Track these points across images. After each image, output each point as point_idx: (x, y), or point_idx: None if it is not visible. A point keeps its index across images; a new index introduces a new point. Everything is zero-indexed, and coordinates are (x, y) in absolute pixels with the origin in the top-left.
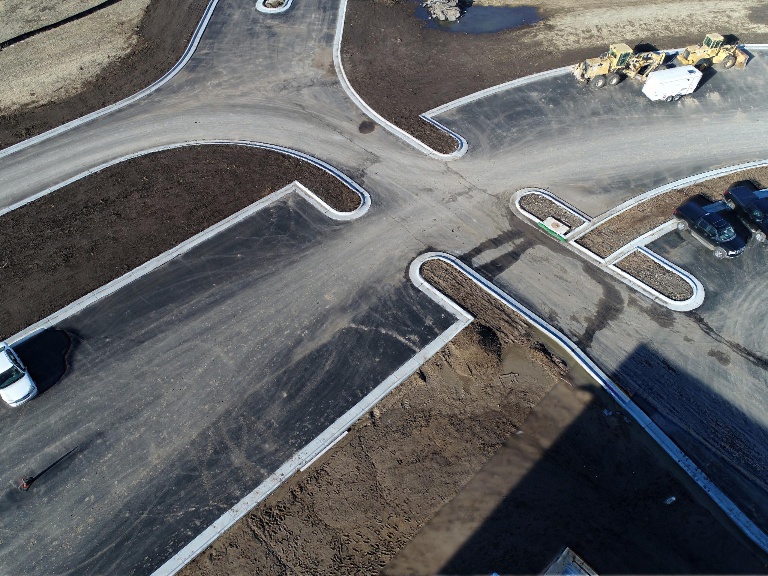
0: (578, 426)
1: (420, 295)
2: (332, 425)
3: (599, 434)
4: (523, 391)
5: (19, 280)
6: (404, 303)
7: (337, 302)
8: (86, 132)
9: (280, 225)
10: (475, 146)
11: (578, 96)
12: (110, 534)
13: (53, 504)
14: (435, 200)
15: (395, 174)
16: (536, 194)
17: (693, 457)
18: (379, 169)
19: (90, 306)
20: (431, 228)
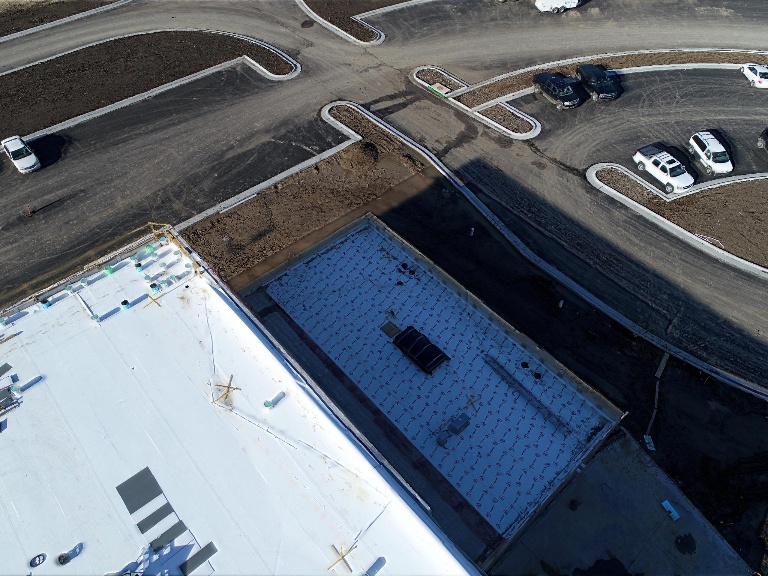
0: (421, 197)
1: (326, 125)
2: (246, 191)
3: (435, 201)
4: (388, 178)
5: (30, 106)
6: (313, 129)
7: (263, 127)
8: (86, 22)
9: (228, 82)
10: (391, 38)
11: (483, 8)
12: (85, 239)
13: (48, 224)
14: (351, 71)
15: (324, 54)
16: (431, 69)
17: (499, 215)
18: (312, 50)
19: (81, 123)
20: (344, 87)
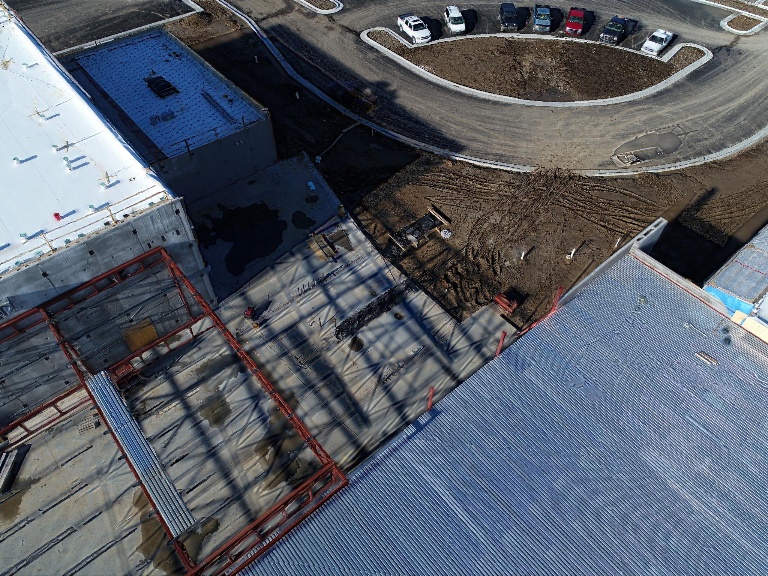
0: (232, 43)
1: (181, 3)
2: (107, 37)
3: (241, 45)
4: (213, 33)
5: None
6: (170, 5)
7: (134, 3)
8: None
9: None
10: None
11: None
12: None
13: None
14: None
15: None
16: None
17: (284, 54)
18: None
19: None
20: None
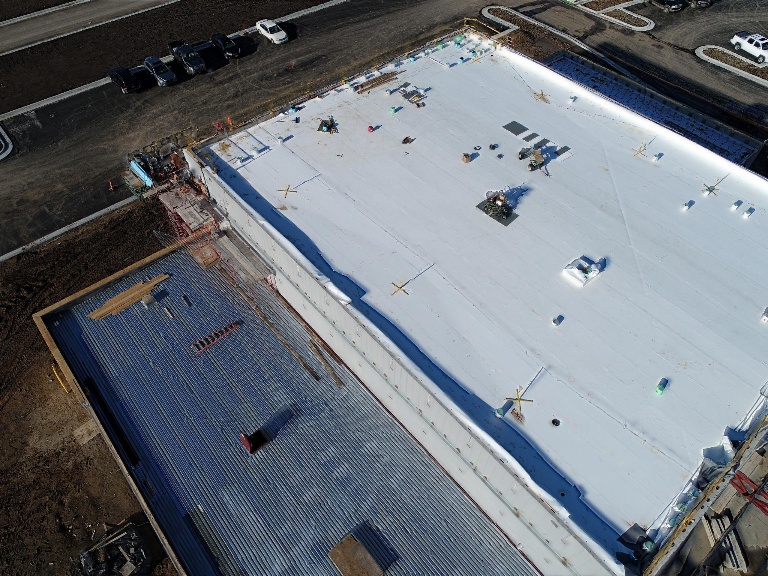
0: None
1: (488, 20)
2: None
3: None
4: (546, 52)
5: (262, 4)
6: None
7: (441, 20)
8: None
9: None
10: None
11: None
12: None
13: (308, 74)
14: None
15: None
16: None
17: (635, 74)
18: None
19: (304, 15)
20: None
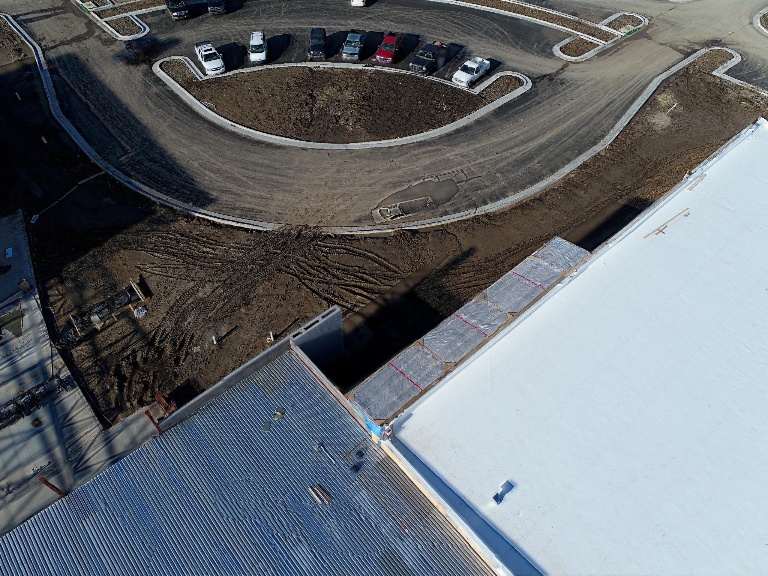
0: (5, 76)
1: None
2: None
3: (13, 79)
4: None
5: None
6: None
7: None
8: None
9: None
10: None
11: None
12: None
13: None
14: None
15: None
16: None
17: (57, 89)
18: None
19: None
20: (8, 3)
